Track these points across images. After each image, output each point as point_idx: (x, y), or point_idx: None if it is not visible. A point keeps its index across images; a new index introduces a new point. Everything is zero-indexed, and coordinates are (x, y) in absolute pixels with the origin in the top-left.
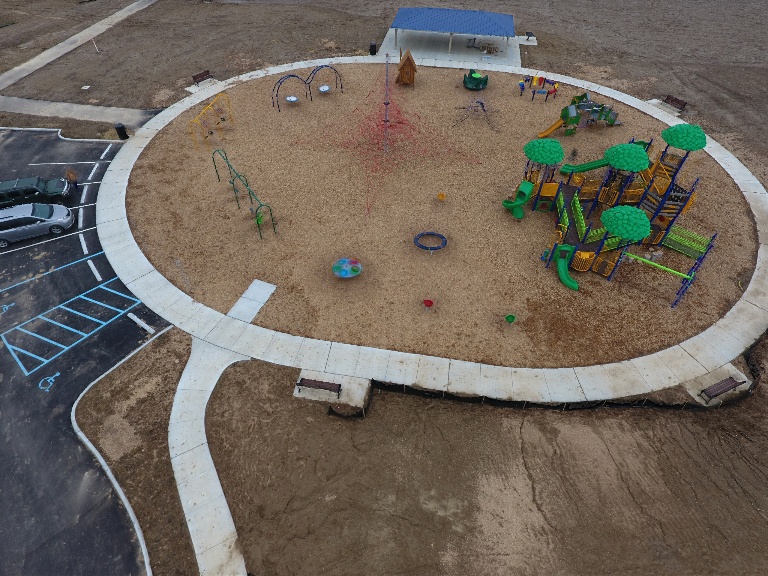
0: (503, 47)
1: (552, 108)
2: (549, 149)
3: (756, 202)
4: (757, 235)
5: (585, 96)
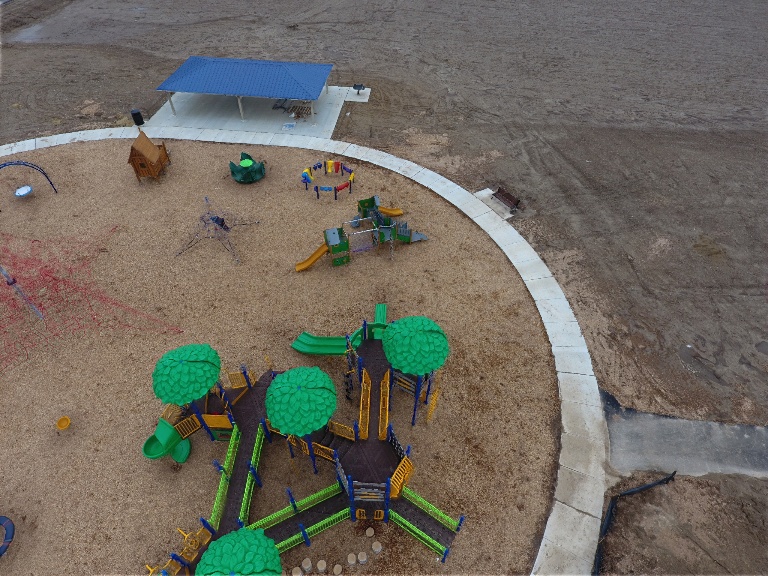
0: (320, 106)
1: (340, 211)
2: (177, 380)
3: (572, 396)
4: (555, 478)
5: (374, 200)
